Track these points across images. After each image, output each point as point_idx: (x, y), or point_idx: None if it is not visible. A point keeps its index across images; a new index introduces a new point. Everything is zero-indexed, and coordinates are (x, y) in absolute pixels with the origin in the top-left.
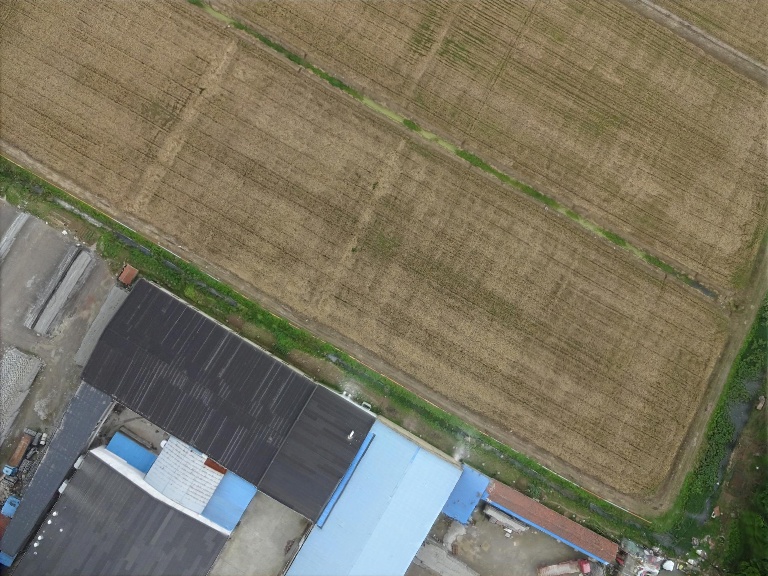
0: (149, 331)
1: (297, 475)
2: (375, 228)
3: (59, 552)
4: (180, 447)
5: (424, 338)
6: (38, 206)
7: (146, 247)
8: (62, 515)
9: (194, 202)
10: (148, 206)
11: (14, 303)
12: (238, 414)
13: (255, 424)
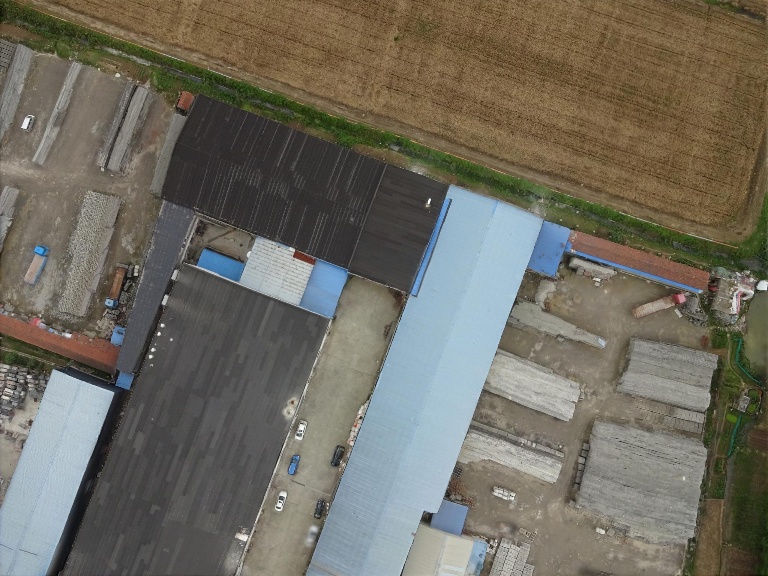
0: (217, 139)
1: (384, 250)
2: (413, 14)
3: (173, 359)
4: (267, 246)
5: (480, 110)
6: (88, 54)
7: (197, 76)
8: (169, 326)
9: (234, 23)
10: (191, 35)
11: (84, 150)
12: (317, 201)
13: (335, 208)
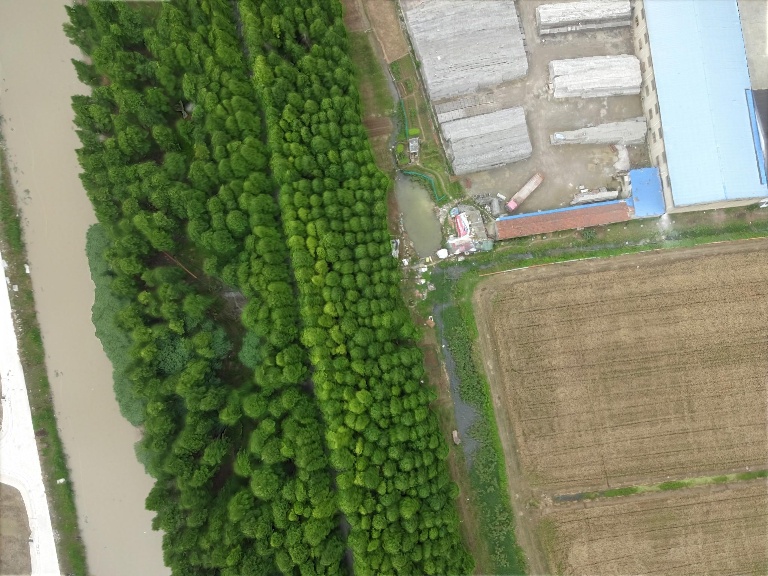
0: None
1: None
2: None
3: None
4: None
5: (761, 288)
6: None
7: None
8: None
9: None
10: None
11: None
12: None
13: None
